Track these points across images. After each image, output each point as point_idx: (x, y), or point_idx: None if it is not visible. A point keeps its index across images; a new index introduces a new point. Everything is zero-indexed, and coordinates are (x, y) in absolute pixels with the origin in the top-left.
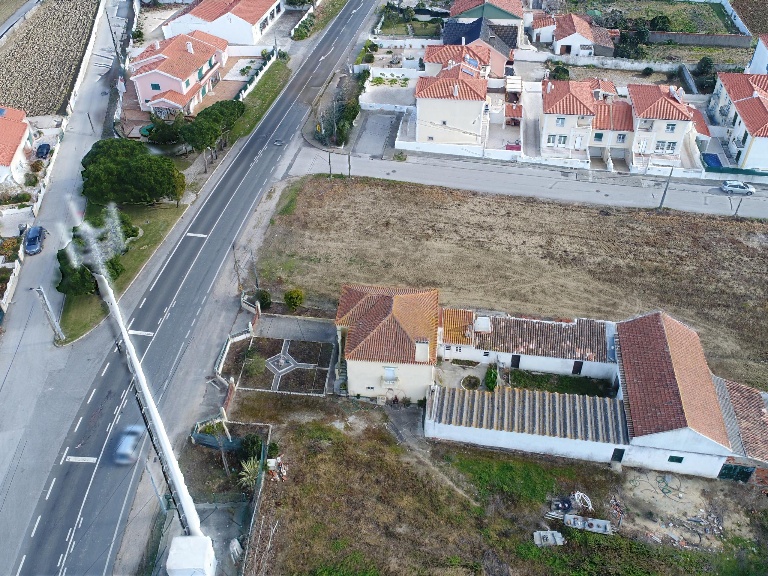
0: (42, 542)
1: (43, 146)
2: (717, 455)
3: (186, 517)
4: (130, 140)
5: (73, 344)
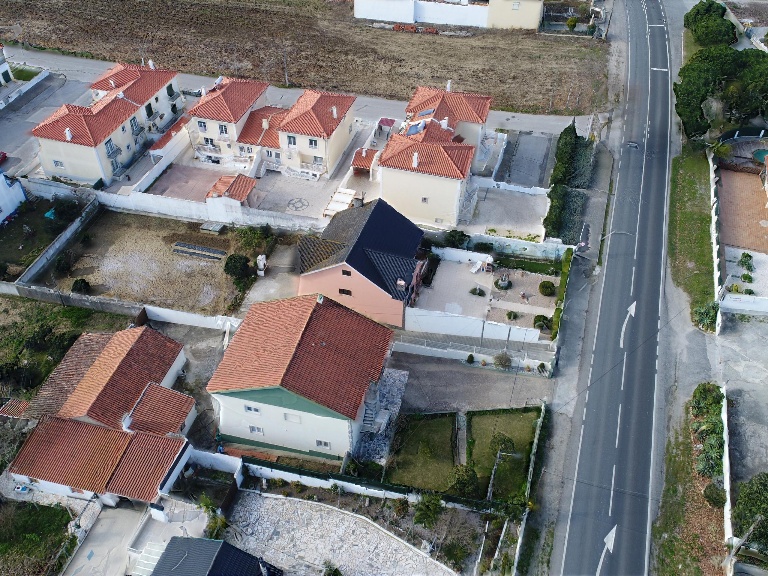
0: None
1: None
2: None
3: None
4: (767, 84)
5: None
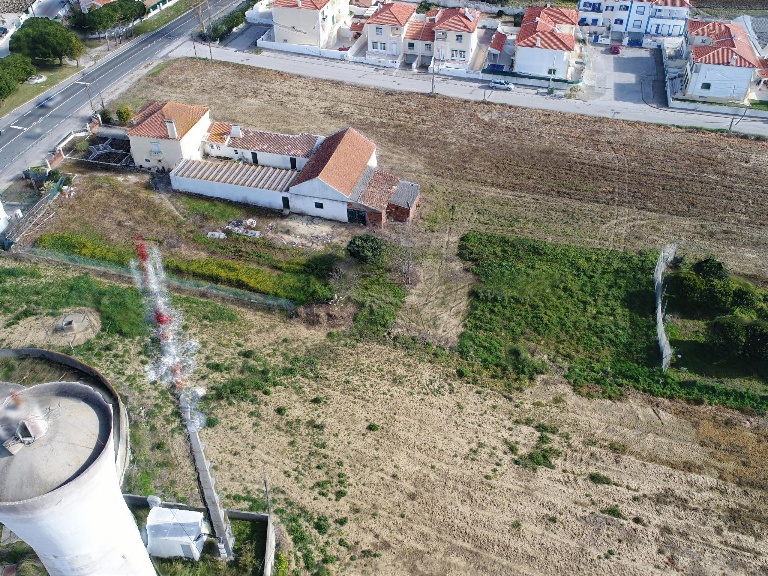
0: None
1: (1, 28)
2: (341, 201)
3: None
4: None
5: None
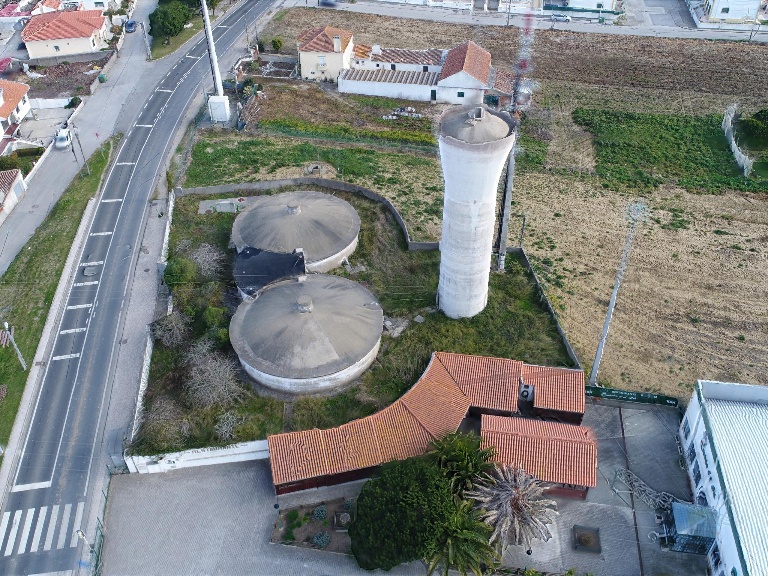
0: (149, 110)
1: None
2: (479, 89)
3: (217, 87)
4: None
5: (157, 60)
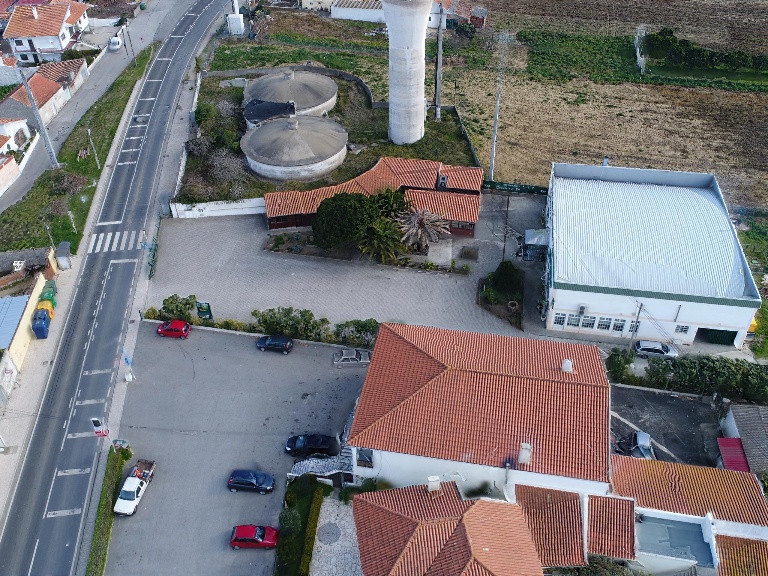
0: (181, 26)
1: None
2: (443, 14)
3: None
4: None
5: None
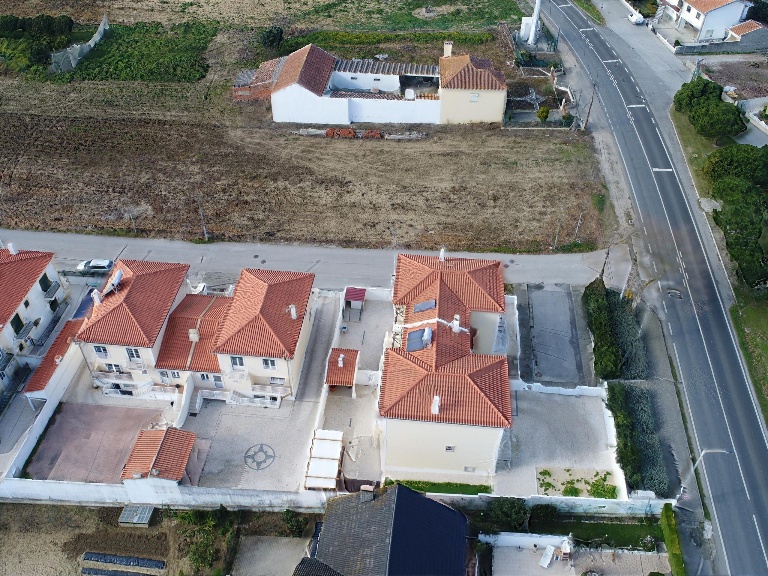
0: None
1: None
2: None
3: None
4: None
5: None
